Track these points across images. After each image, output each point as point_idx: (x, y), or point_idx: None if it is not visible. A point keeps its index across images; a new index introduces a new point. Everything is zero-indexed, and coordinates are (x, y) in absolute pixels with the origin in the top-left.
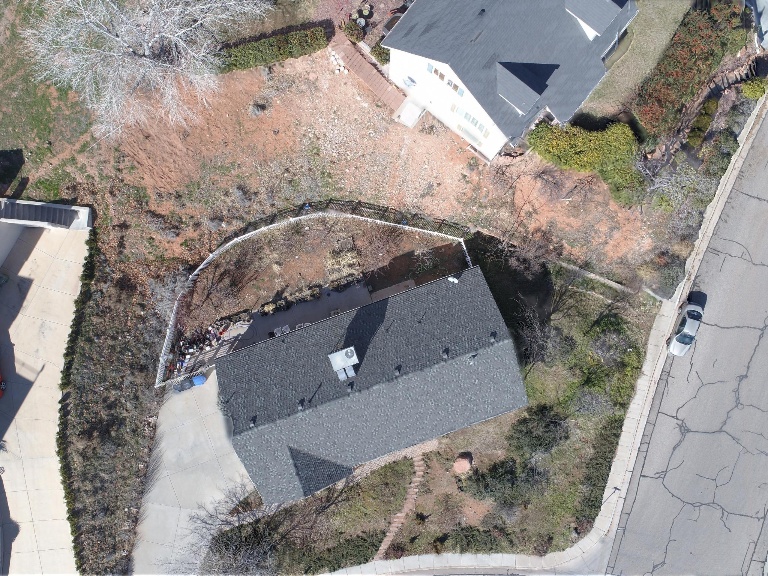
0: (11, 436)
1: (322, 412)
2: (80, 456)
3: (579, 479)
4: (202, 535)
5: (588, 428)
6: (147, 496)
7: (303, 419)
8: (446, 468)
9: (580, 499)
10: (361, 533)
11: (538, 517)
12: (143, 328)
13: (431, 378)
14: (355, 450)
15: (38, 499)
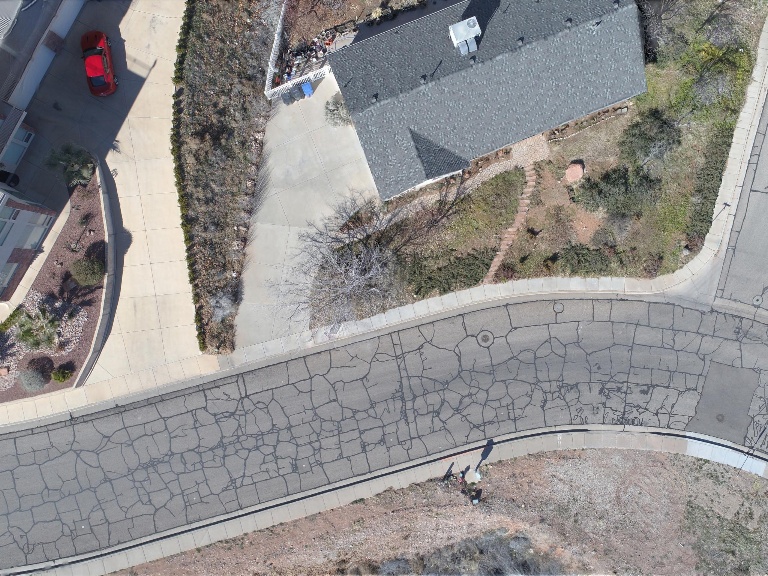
0: (124, 135)
1: (444, 86)
2: (193, 157)
3: (690, 191)
4: (312, 254)
5: (700, 135)
6: (255, 216)
7: (425, 94)
8: (558, 177)
9: (691, 214)
10: (472, 250)
11: (649, 233)
12: (249, 36)
13: (554, 49)
14: (474, 138)
15: (151, 205)
